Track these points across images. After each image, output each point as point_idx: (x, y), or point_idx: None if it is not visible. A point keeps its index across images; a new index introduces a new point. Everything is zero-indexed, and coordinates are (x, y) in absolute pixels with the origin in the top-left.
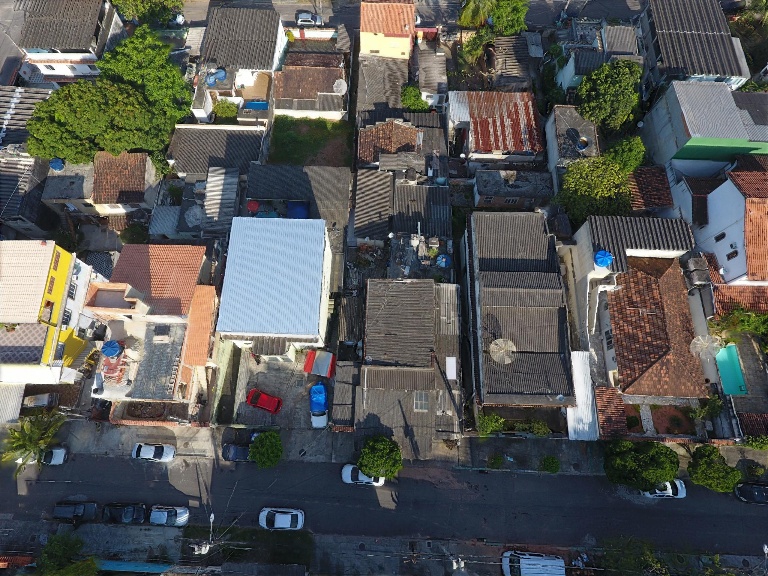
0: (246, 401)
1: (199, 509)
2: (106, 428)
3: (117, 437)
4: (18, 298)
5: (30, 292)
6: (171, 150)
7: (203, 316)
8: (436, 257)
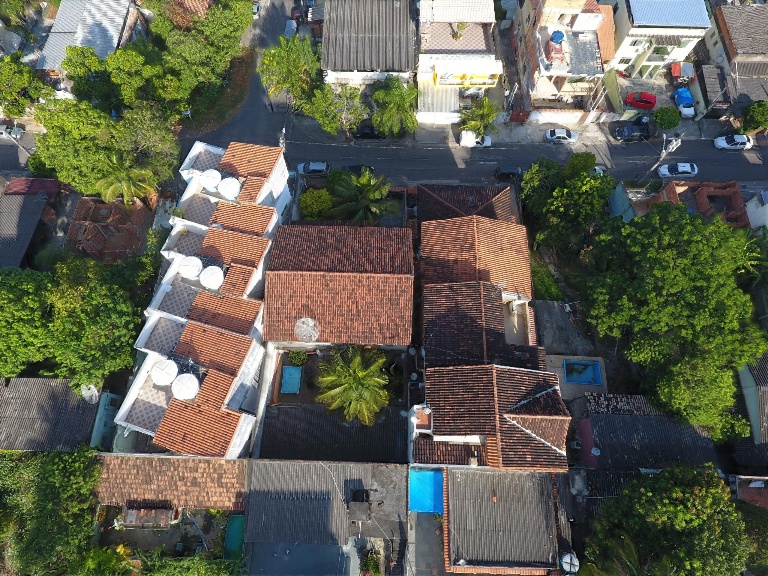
0: (627, 100)
1: (606, 171)
2: (513, 126)
3: (524, 131)
4: (476, 6)
5: (484, 3)
6: None
7: (607, 26)
8: None
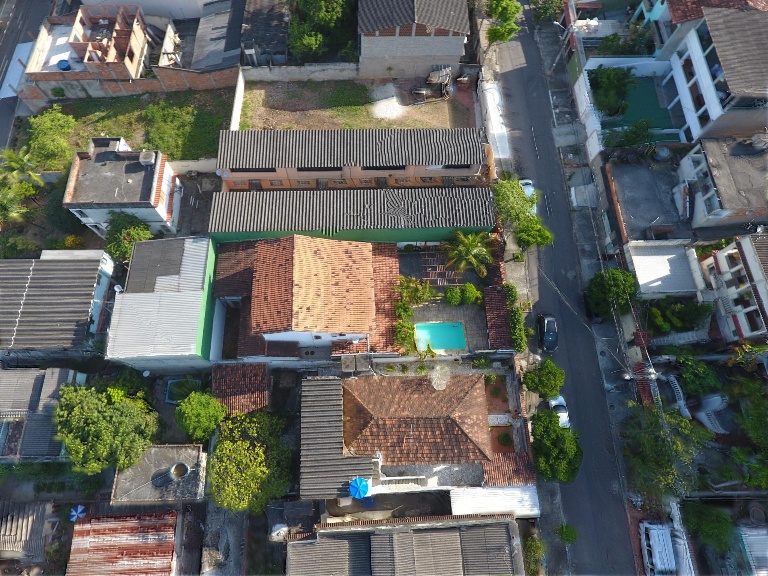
0: None
1: None
2: None
3: None
4: None
5: None
6: None
7: None
8: None
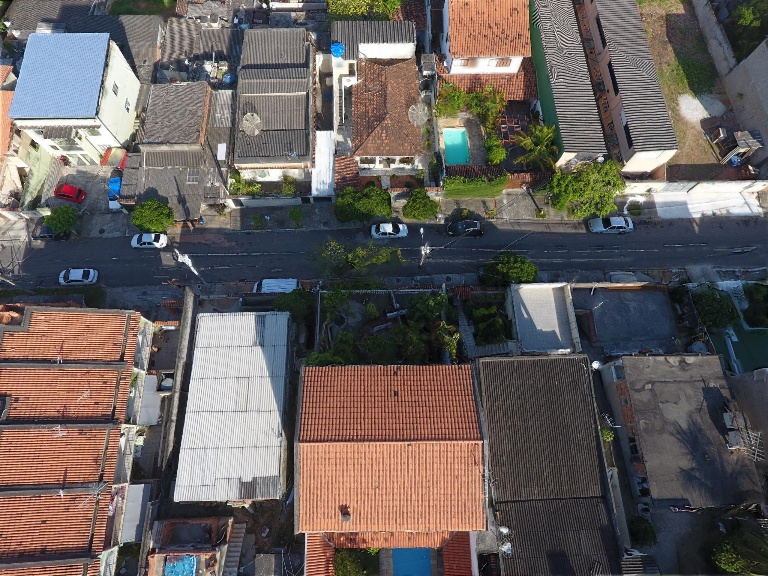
0: None
1: None
2: None
3: None
4: None
5: None
6: (8, 14)
7: (5, 115)
8: (224, 76)
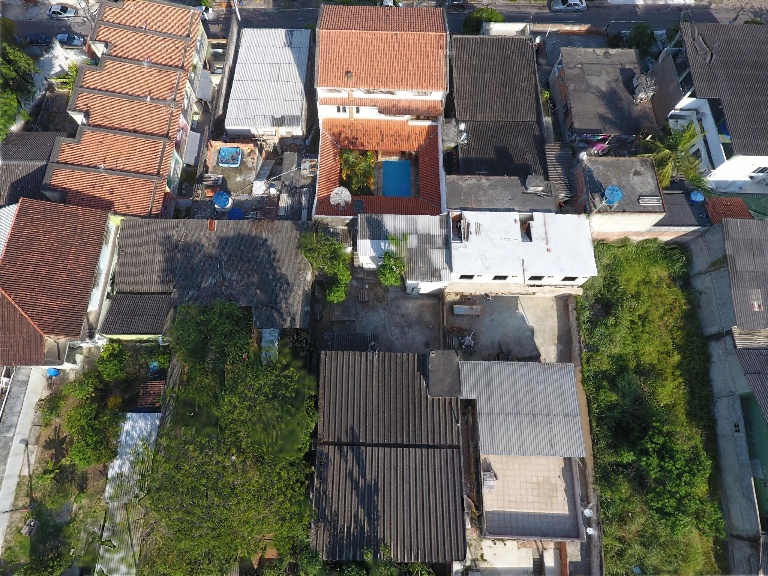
0: None
1: None
2: (30, 7)
3: (38, 11)
4: None
5: None
6: None
7: None
8: None
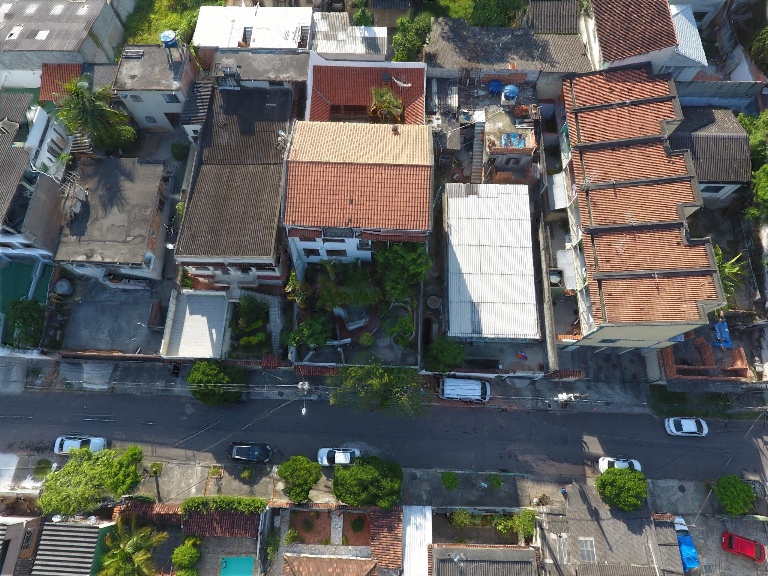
0: None
1: (762, 434)
2: None
3: None
4: None
5: None
6: None
7: None
8: None
